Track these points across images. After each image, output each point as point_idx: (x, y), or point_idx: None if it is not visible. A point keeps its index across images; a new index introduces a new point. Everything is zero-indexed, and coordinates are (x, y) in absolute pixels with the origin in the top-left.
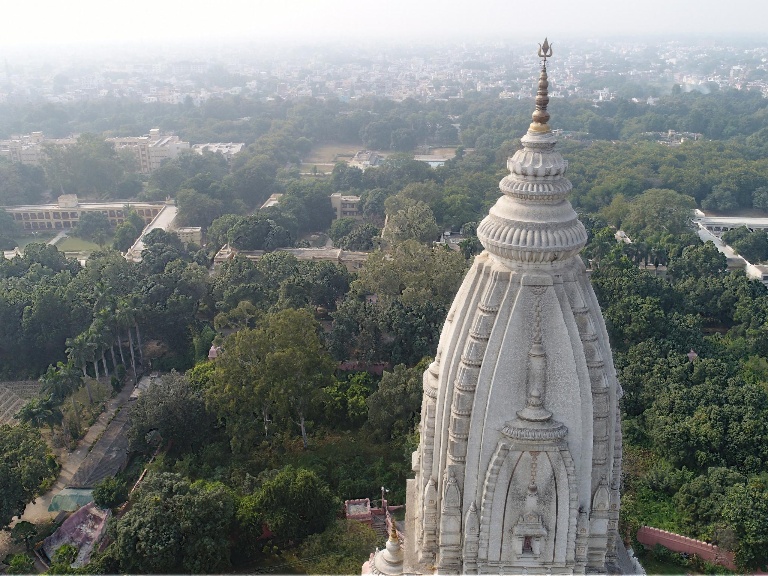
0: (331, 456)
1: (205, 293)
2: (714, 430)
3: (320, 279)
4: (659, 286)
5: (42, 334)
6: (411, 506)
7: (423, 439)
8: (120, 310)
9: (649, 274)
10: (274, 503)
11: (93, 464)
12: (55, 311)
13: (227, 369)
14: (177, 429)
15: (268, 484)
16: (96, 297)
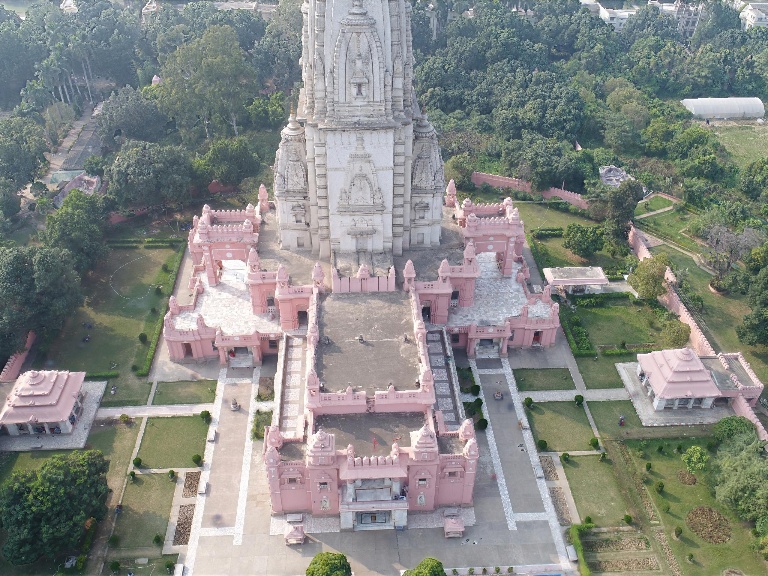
0: (258, 142)
1: (140, 37)
2: (535, 115)
3: (239, 24)
4: (521, 23)
5: (6, 70)
6: (302, 97)
7: (303, 40)
8: (73, 43)
9: (514, 14)
10: (219, 159)
11: (76, 156)
12: (14, 48)
13: (172, 79)
14: (138, 129)
15: (213, 146)
16: (48, 35)
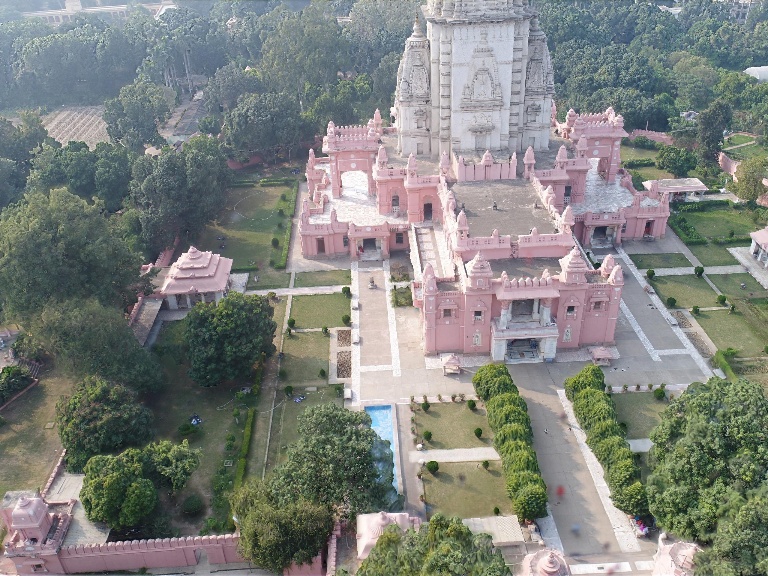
0: None
1: (229, 40)
2: (610, 76)
3: None
4: (581, 15)
5: (114, 65)
6: None
7: None
8: (177, 35)
9: (574, 7)
10: (325, 109)
11: (186, 125)
12: (122, 45)
13: (273, 53)
14: None
15: (320, 98)
16: (153, 32)
